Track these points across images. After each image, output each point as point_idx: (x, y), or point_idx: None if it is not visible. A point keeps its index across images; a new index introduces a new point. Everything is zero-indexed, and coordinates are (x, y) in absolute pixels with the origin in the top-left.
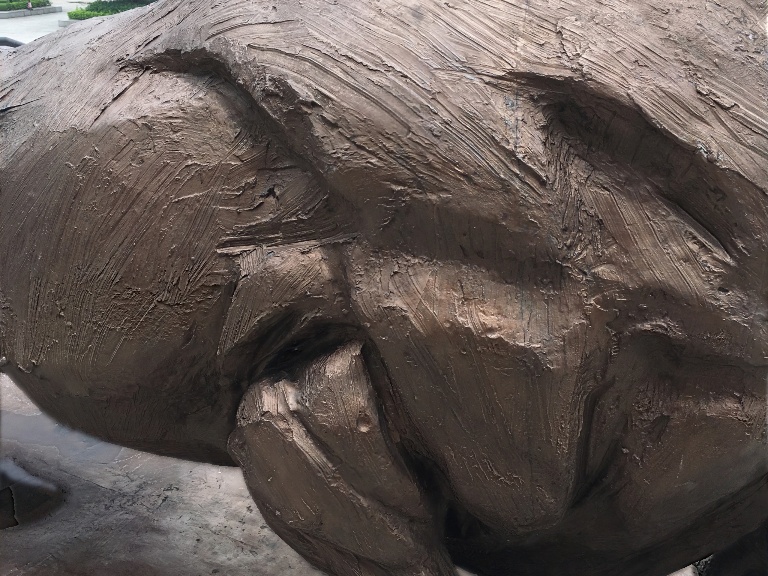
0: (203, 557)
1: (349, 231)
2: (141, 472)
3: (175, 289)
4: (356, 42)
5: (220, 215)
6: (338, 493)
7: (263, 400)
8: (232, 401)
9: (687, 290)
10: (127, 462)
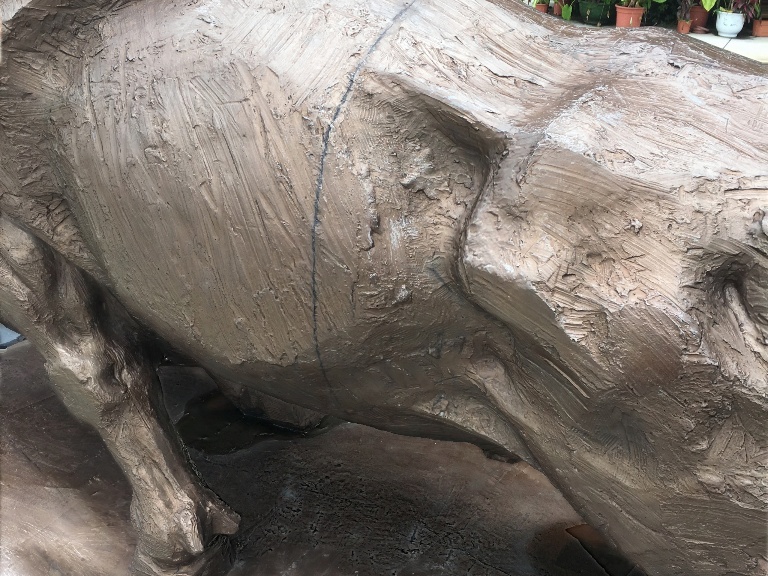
0: (352, 476)
1: None
2: None
3: None
4: None
5: None
6: None
7: None
8: None
9: None
10: None
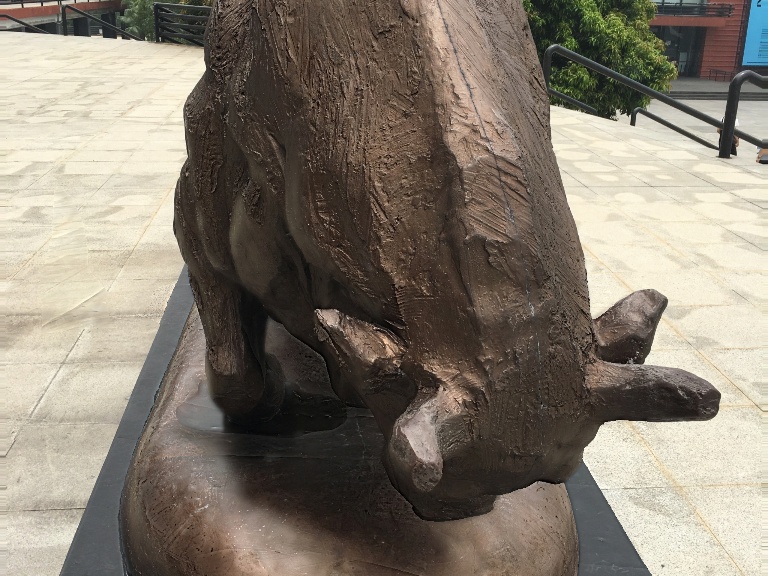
0: None
1: None
2: None
3: None
4: None
5: None
6: None
7: None
8: None
9: (232, 91)
10: None
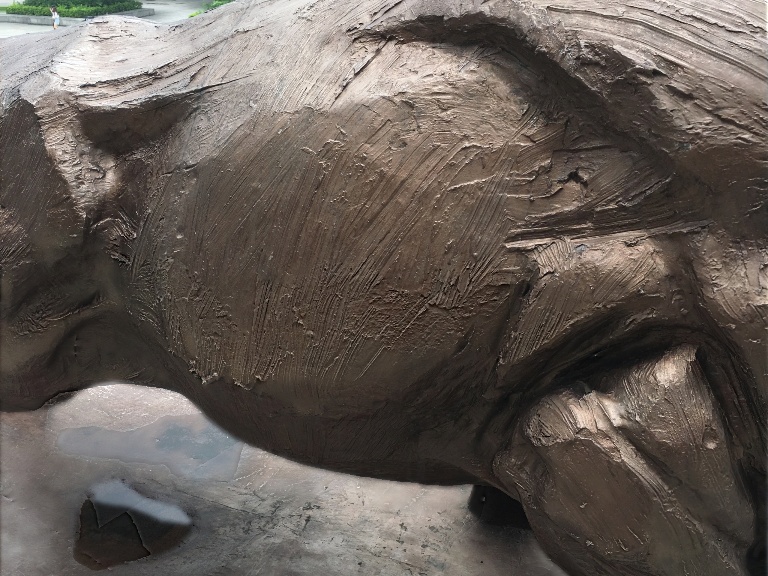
0: None
1: (694, 219)
2: (269, 490)
3: (453, 290)
4: (703, 0)
5: (509, 204)
6: (674, 519)
7: (575, 415)
8: (487, 415)
9: None
10: (249, 479)
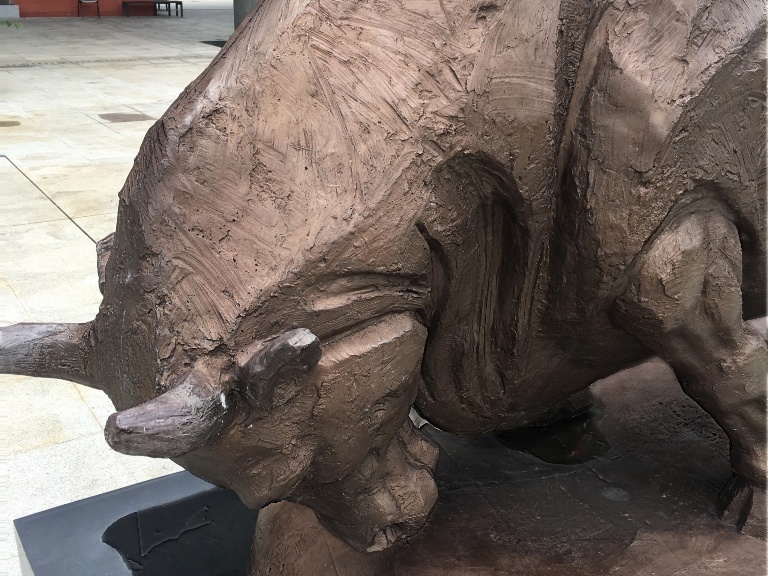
0: (680, 401)
1: None
2: None
3: None
4: None
5: None
6: None
7: None
8: None
9: None
10: None
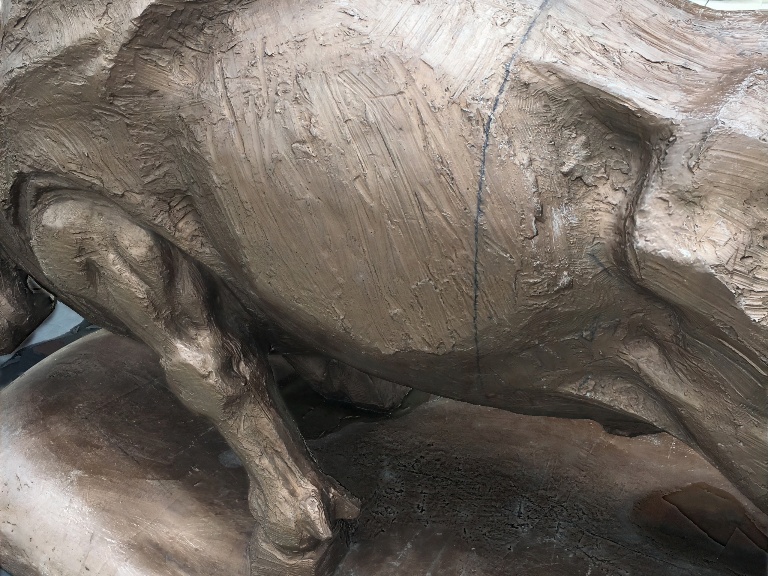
0: (447, 455)
1: None
2: (577, 562)
3: None
4: None
5: None
6: None
7: None
8: None
9: None
10: None
